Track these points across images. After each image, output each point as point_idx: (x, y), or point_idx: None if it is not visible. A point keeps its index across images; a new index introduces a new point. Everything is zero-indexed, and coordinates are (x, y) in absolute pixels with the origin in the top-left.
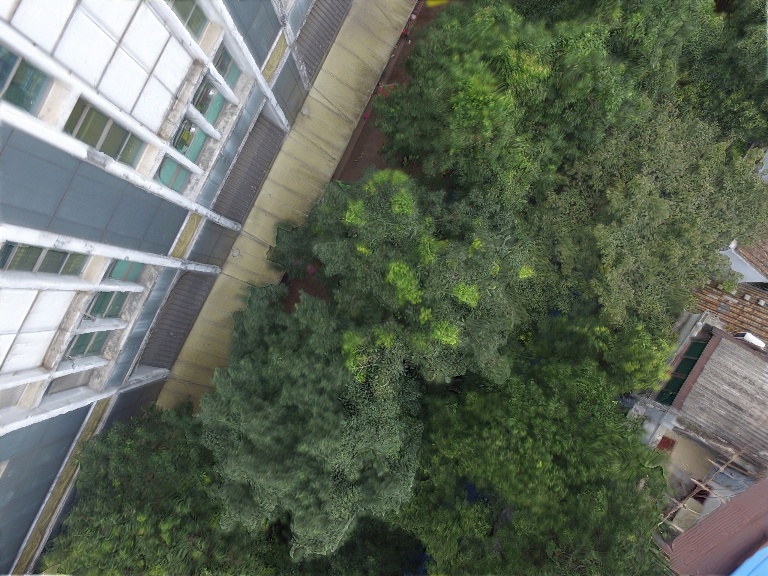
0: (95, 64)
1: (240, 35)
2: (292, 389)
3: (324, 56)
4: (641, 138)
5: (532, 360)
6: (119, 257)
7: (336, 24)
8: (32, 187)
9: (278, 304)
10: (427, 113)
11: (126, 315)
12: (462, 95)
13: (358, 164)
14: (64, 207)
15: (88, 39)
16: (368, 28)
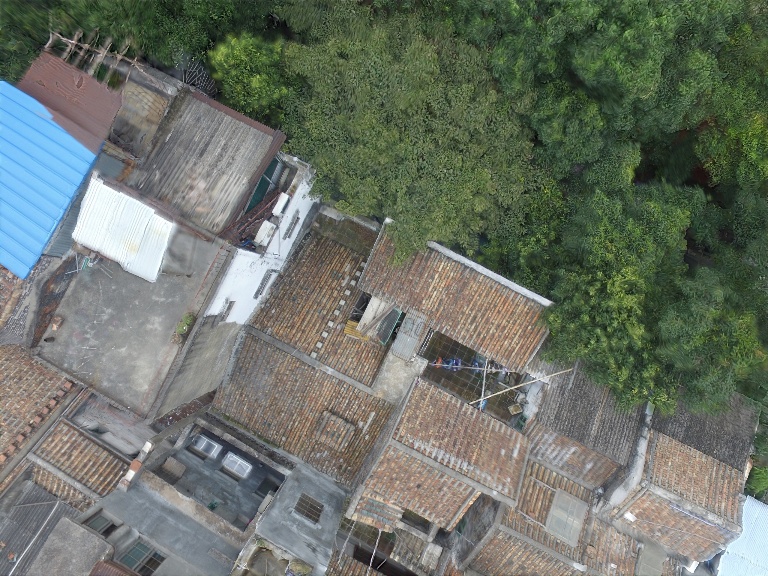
0: None
1: None
2: None
3: None
4: None
5: None
6: None
7: None
8: None
9: None
10: None
11: None
12: None
13: None
14: None
15: None
16: None
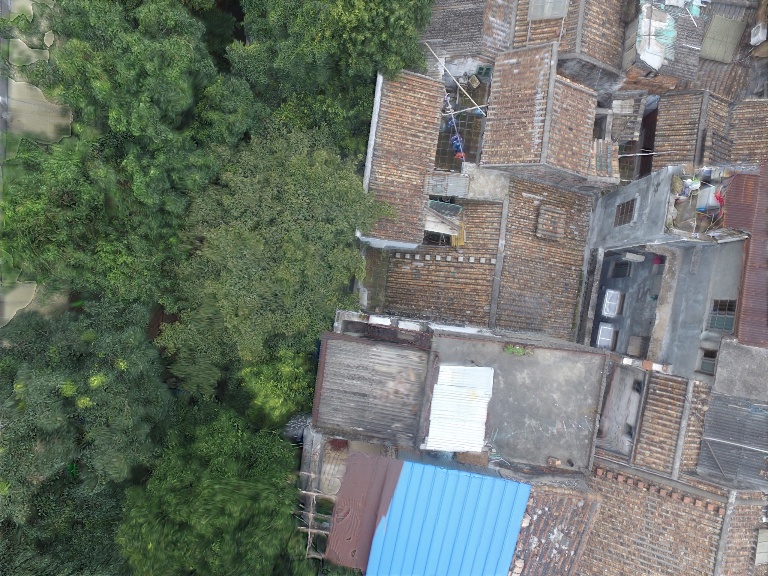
0: None
1: None
2: None
3: None
4: None
5: None
6: None
7: None
8: None
9: None
10: None
11: None
12: (8, 239)
13: None
14: None
15: None
16: None
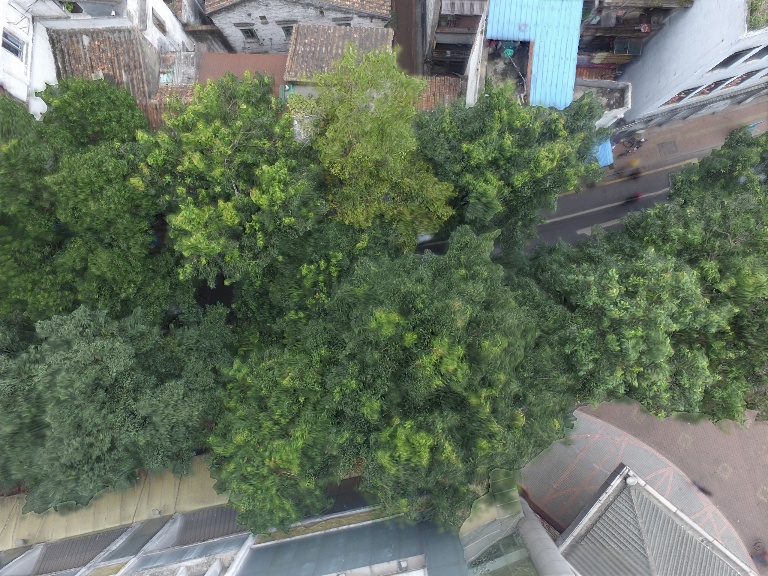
0: None
1: None
2: None
3: None
4: None
5: None
6: None
7: None
8: None
9: None
10: None
11: None
12: None
13: None
14: None
15: None
16: None
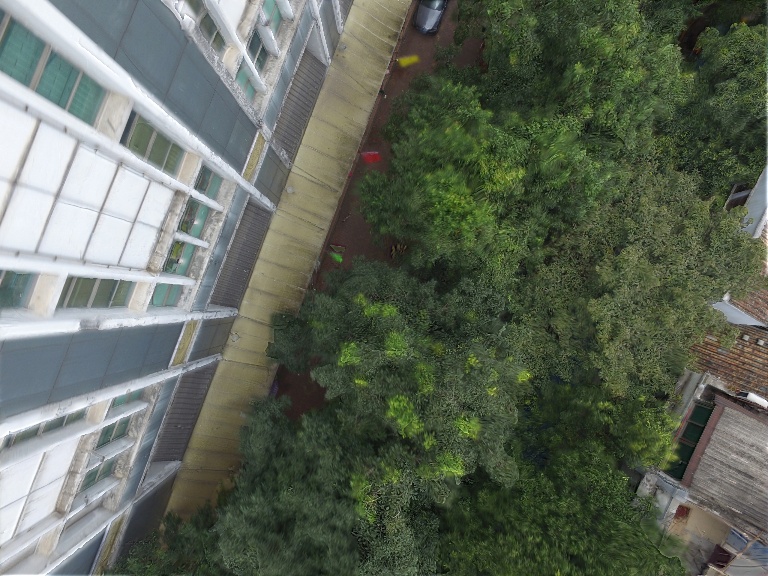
0: (79, 238)
1: (218, 157)
2: (305, 521)
3: (302, 132)
4: (624, 203)
5: (539, 425)
6: (121, 393)
7: (311, 100)
8: (29, 374)
9: (282, 418)
10: (410, 207)
11: (133, 431)
12: (443, 195)
13: (347, 224)
14: (62, 376)
15: (70, 221)
16: (343, 97)
